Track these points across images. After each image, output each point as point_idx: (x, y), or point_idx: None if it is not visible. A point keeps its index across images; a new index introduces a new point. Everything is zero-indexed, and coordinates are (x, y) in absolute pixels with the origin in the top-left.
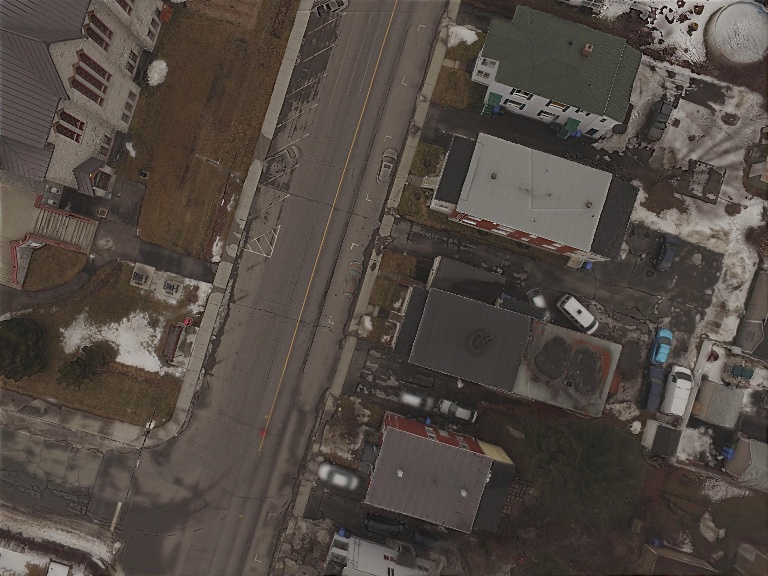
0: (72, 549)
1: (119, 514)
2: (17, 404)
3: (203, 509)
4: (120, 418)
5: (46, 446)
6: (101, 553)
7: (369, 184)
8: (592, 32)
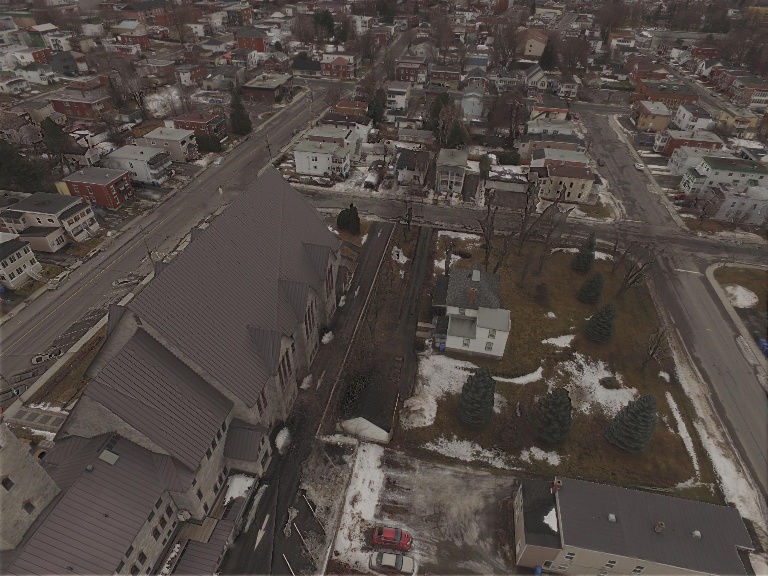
0: None
1: None
2: None
3: None
4: None
5: None
6: None
7: None
8: None
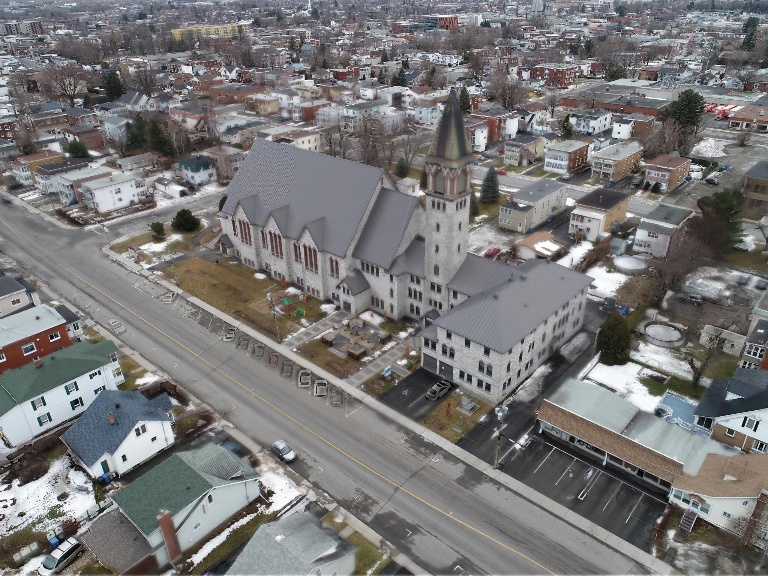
0: None
1: None
2: None
3: None
4: None
5: None
6: None
7: None
8: (48, 386)
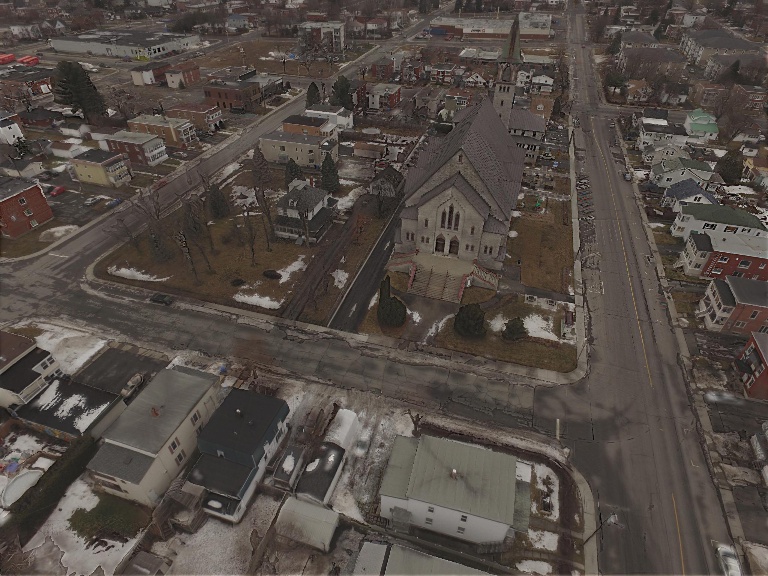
0: (529, 452)
1: (560, 427)
2: (464, 359)
3: (628, 424)
4: (540, 366)
5: (490, 383)
6: (555, 456)
7: (643, 268)
8: None
